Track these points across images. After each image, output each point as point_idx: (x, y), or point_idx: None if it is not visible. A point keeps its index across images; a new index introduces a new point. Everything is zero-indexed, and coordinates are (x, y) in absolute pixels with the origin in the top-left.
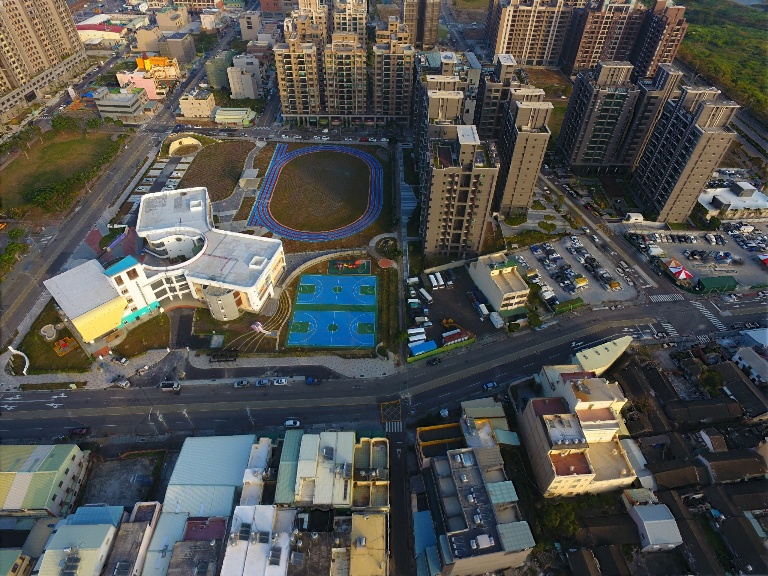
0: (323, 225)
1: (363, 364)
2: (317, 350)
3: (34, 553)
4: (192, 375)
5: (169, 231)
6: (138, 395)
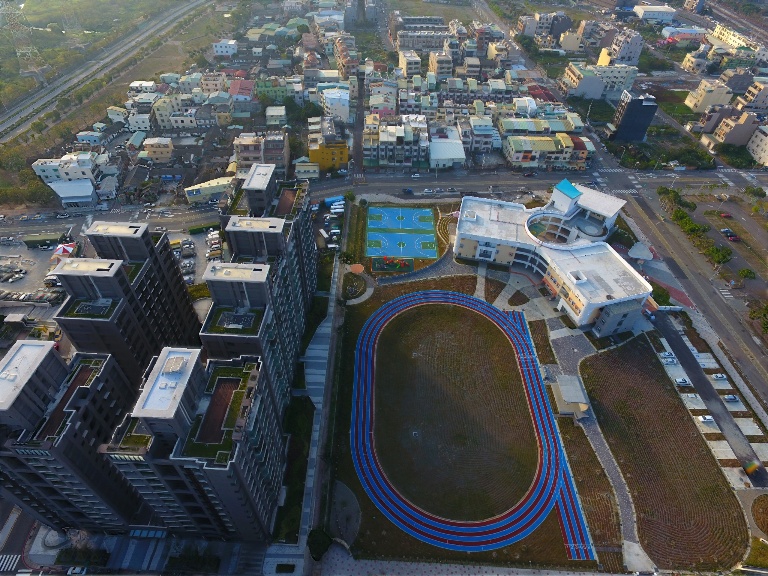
0: (431, 315)
1: (377, 199)
2: (409, 206)
3: (505, 140)
4: (486, 195)
5: (577, 248)
6: (511, 188)
